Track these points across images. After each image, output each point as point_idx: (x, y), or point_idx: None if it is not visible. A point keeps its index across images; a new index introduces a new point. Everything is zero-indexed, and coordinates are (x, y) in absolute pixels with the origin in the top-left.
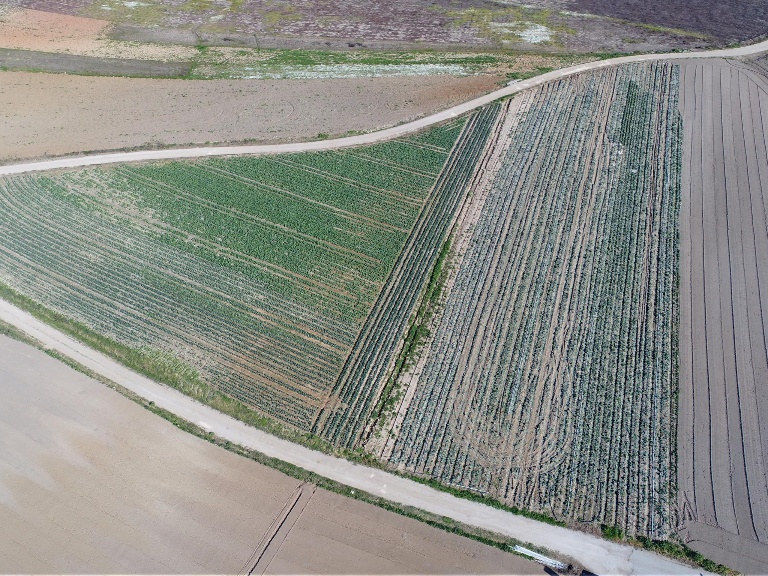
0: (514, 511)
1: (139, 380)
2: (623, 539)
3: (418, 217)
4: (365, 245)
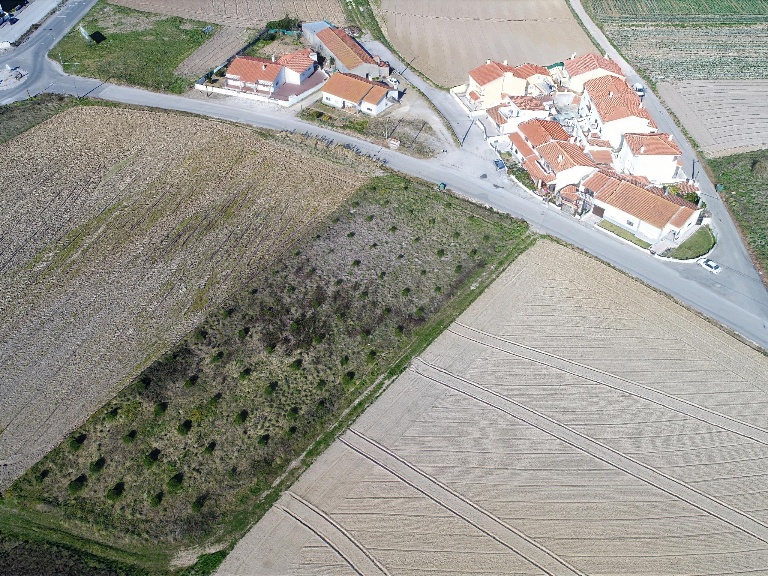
0: (621, 54)
1: None
2: None
3: (760, 14)
4: (715, 5)
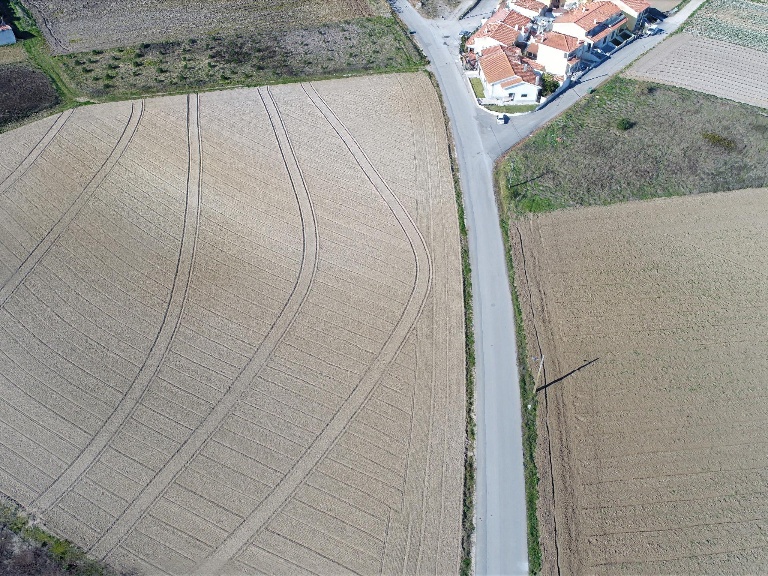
0: None
1: None
2: None
3: None
4: None
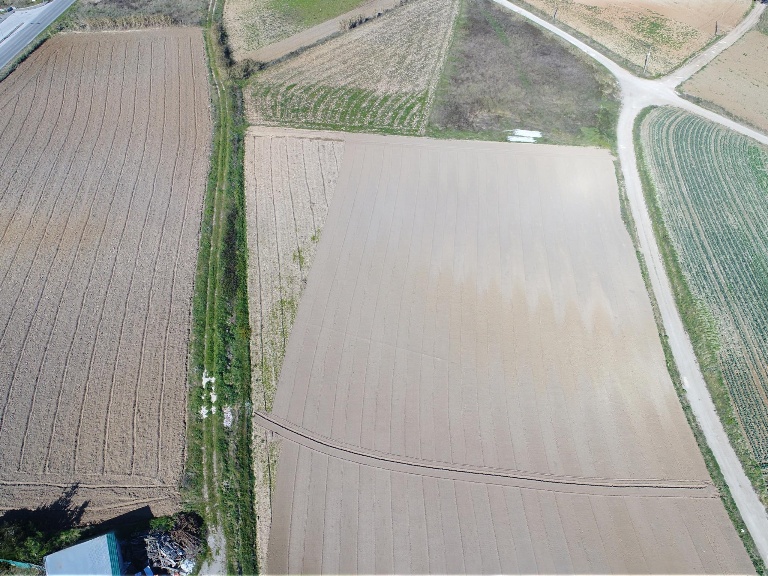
0: None
1: (675, 317)
2: None
3: None
4: None
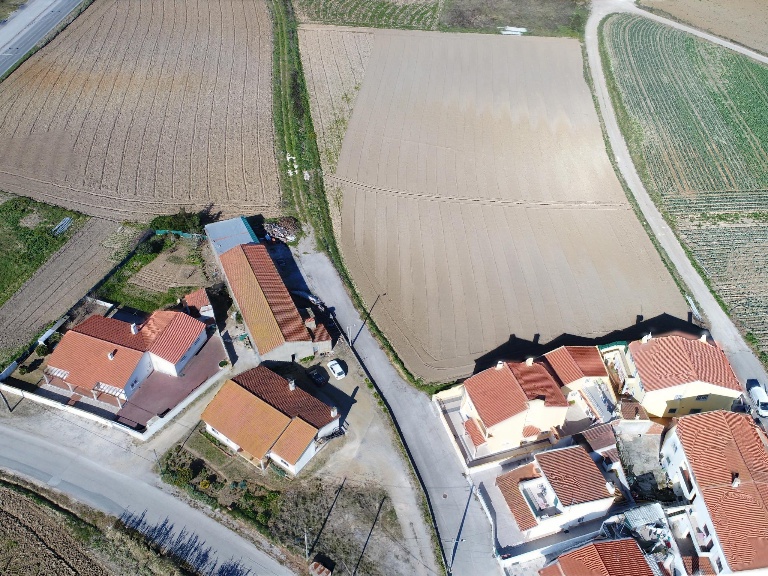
0: (712, 291)
1: (615, 128)
2: (753, 345)
3: None
4: None
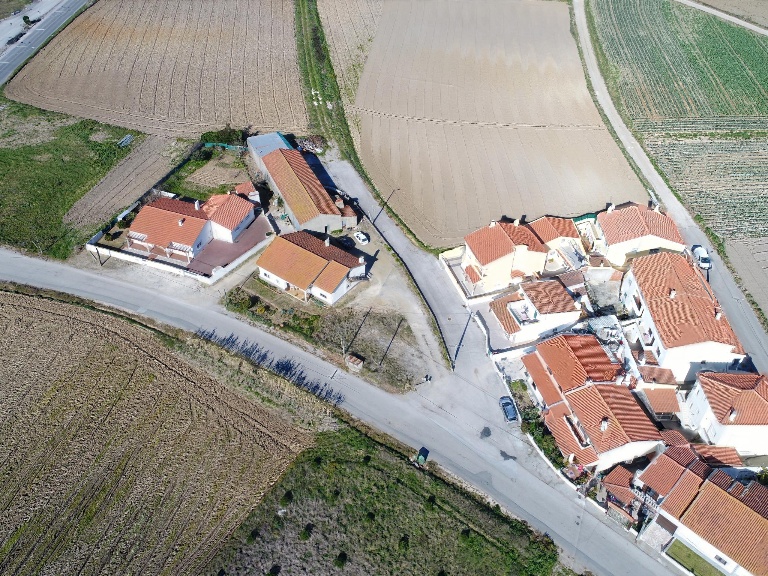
0: (670, 186)
1: (596, 71)
2: (700, 223)
3: None
4: None
